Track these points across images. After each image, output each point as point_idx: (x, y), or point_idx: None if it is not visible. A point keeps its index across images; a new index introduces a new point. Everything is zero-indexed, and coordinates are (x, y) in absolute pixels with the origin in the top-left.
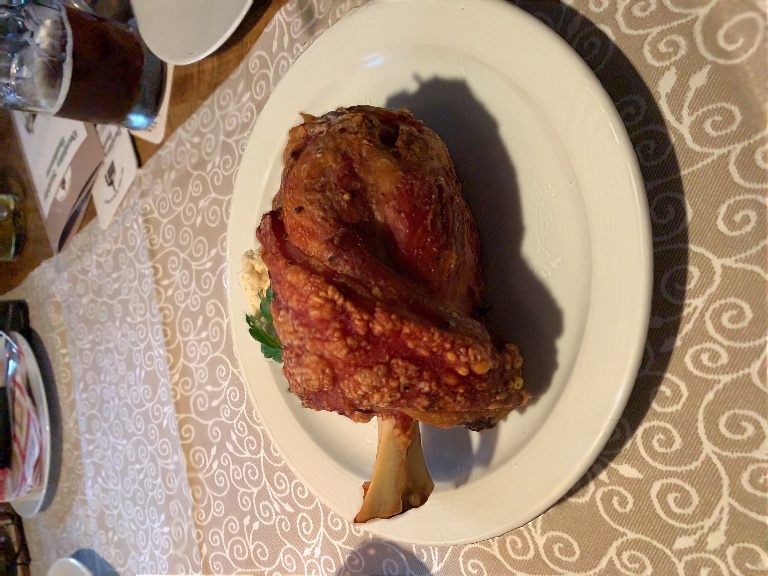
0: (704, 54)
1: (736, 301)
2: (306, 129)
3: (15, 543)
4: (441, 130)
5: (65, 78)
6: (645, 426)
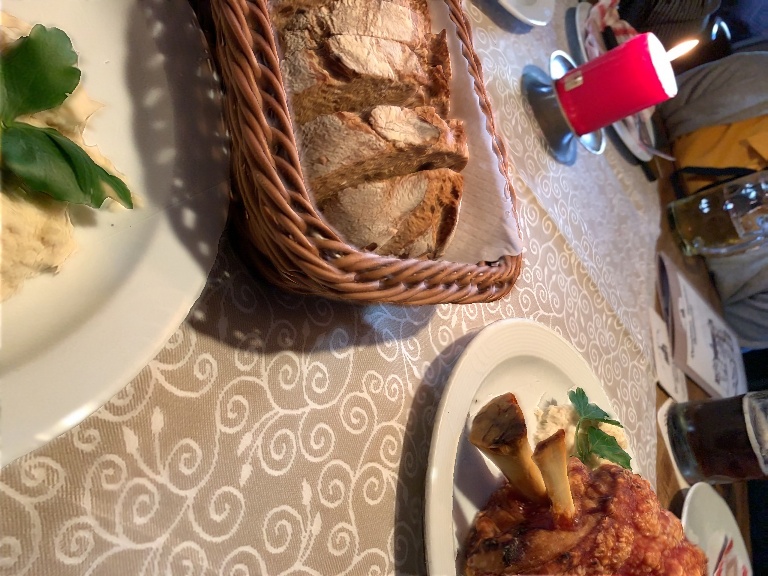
0: None
1: None
2: None
3: (631, 57)
4: None
5: (753, 437)
6: None
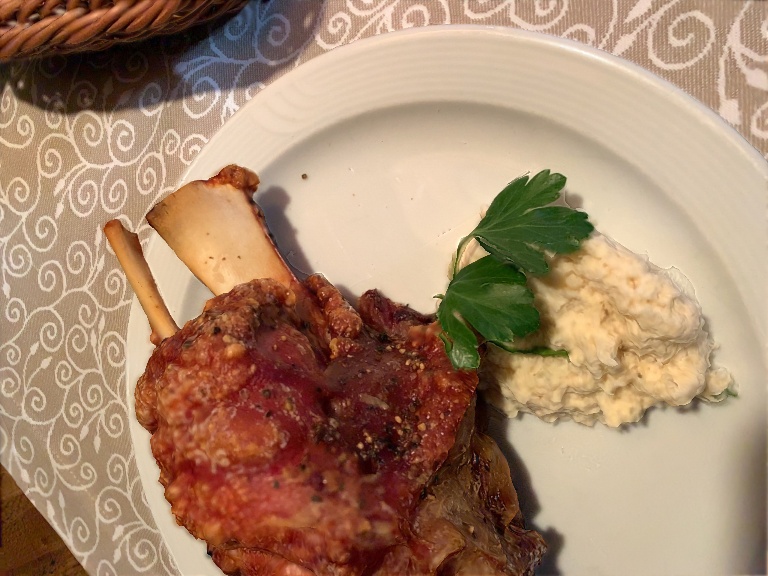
0: None
1: None
2: None
3: None
4: None
5: None
6: None
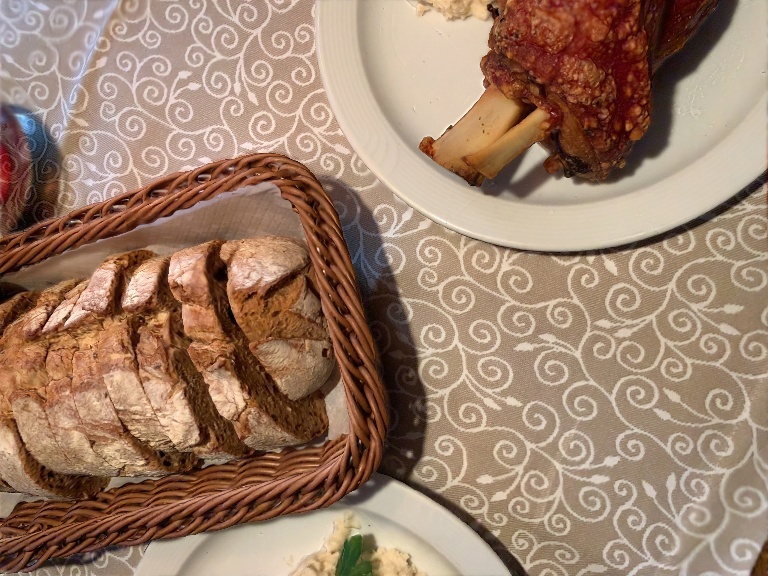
0: None
1: (767, 223)
2: None
3: None
4: None
5: None
6: (647, 249)
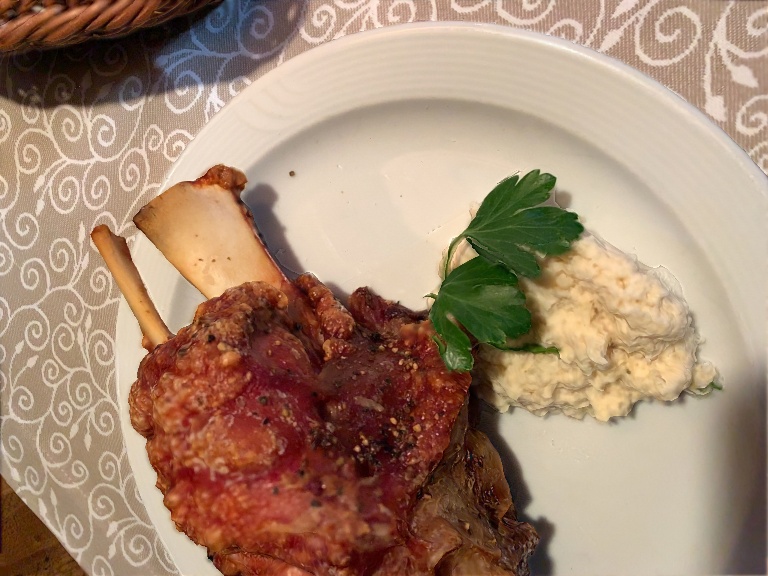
0: None
1: None
2: None
3: None
4: None
5: None
6: None
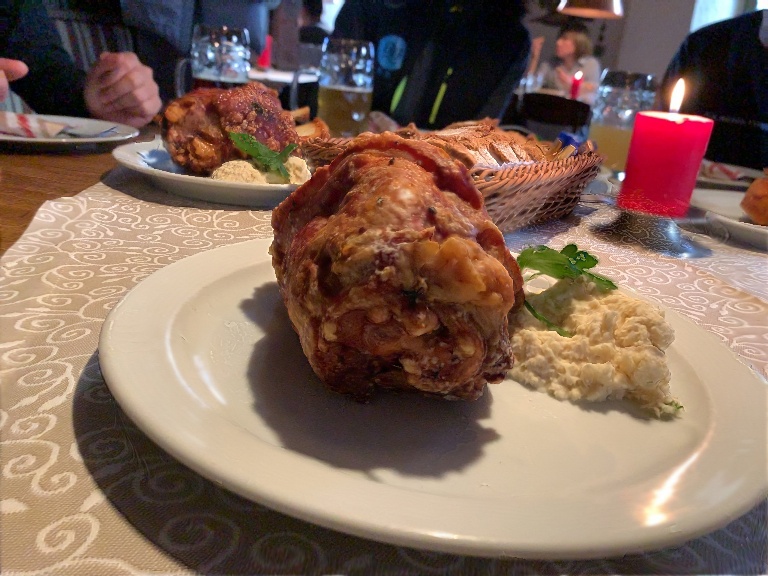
0: (6, 414)
1: (109, 308)
2: (421, 231)
3: None
4: (341, 424)
5: None
6: None
